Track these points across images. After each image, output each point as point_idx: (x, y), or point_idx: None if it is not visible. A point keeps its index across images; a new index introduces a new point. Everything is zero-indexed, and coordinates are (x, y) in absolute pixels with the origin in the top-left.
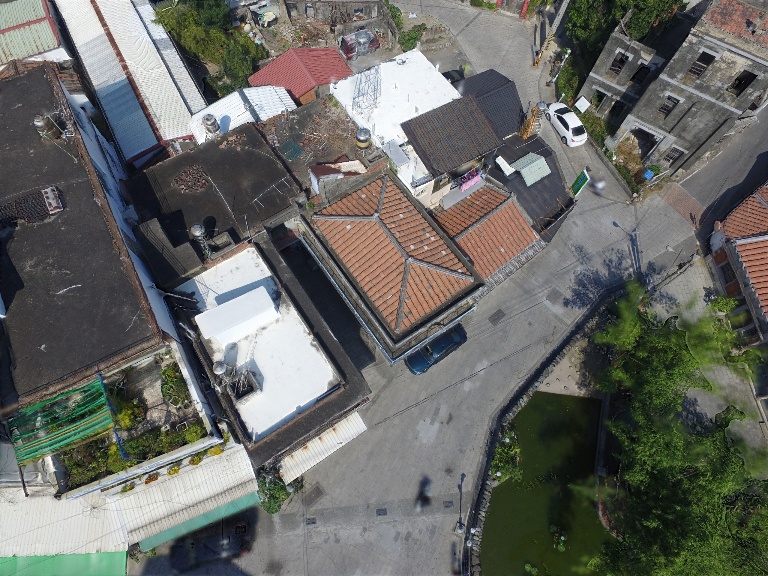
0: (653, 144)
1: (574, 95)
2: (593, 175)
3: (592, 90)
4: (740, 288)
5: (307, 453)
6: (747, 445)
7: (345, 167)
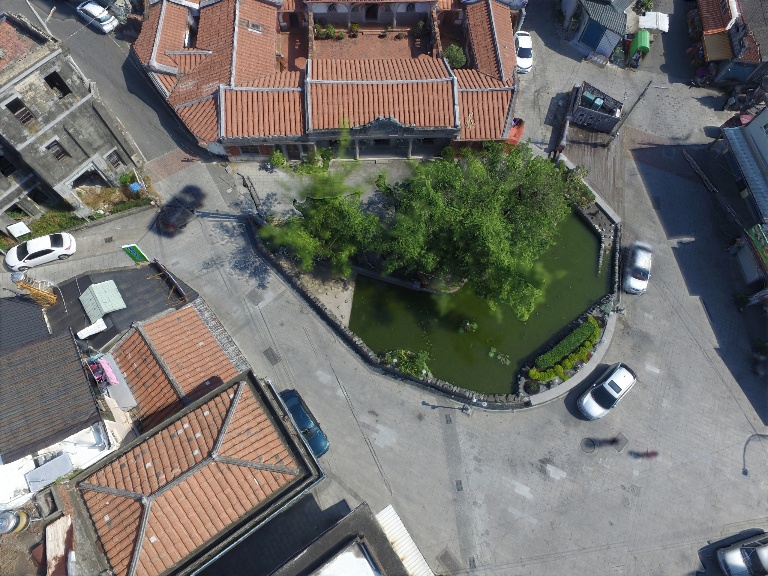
0: (95, 173)
1: (0, 236)
2: (118, 236)
3: (3, 216)
4: (267, 145)
5: (417, 575)
6: (392, 176)
7: (56, 550)
